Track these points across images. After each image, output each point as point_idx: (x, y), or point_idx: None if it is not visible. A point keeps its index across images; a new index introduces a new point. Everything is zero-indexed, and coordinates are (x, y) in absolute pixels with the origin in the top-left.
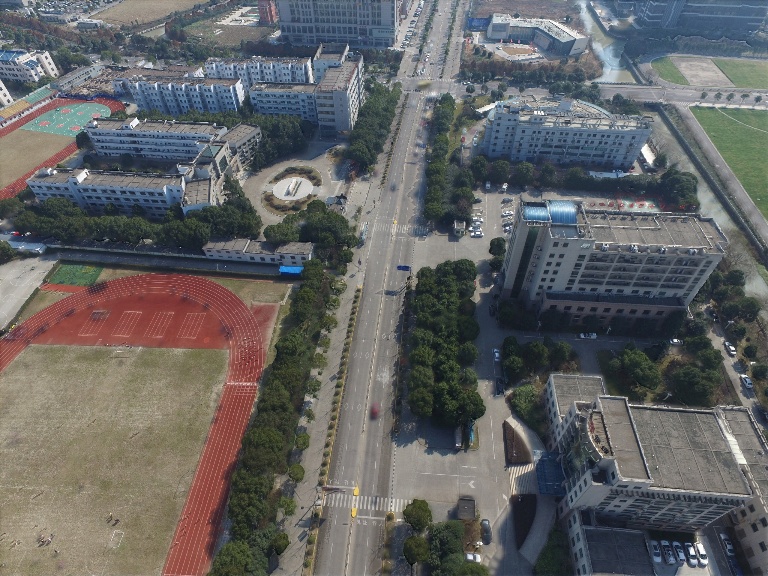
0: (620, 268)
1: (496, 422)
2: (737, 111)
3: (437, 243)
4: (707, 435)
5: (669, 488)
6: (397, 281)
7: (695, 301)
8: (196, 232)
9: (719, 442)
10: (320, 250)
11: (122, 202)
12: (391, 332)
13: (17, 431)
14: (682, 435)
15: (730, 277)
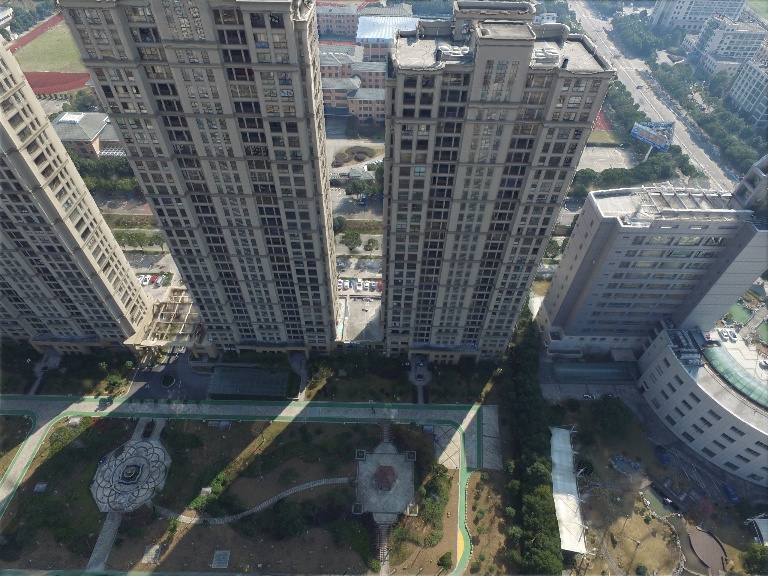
0: (708, 5)
1: None
2: None
3: (609, 20)
4: None
5: (742, 30)
6: None
7: None
8: None
9: None
10: None
11: None
12: (606, 39)
13: None
14: None
15: None
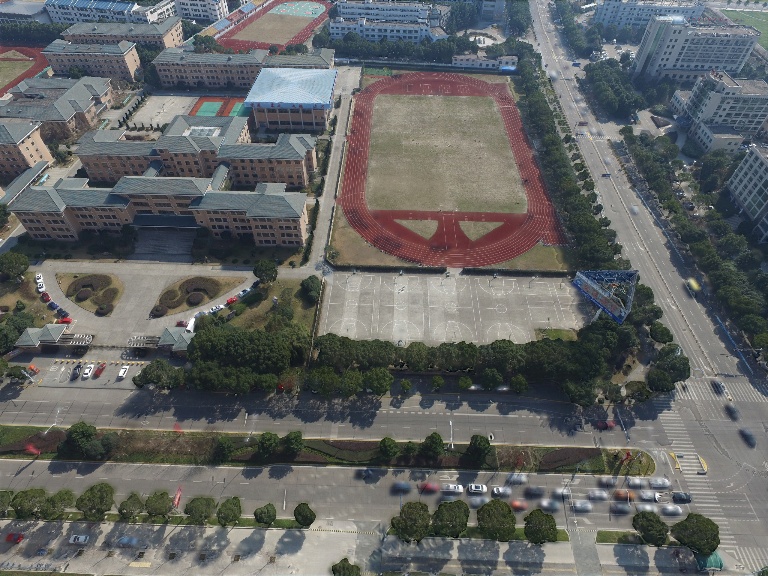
0: (705, 50)
1: (647, 117)
2: (751, 12)
3: (584, 63)
4: (760, 84)
5: (747, 94)
6: (569, 76)
7: (740, 77)
8: (451, 47)
9: (765, 86)
10: (522, 59)
11: (388, 39)
12: (576, 92)
13: (403, 119)
14: (749, 84)
15: (757, 70)
